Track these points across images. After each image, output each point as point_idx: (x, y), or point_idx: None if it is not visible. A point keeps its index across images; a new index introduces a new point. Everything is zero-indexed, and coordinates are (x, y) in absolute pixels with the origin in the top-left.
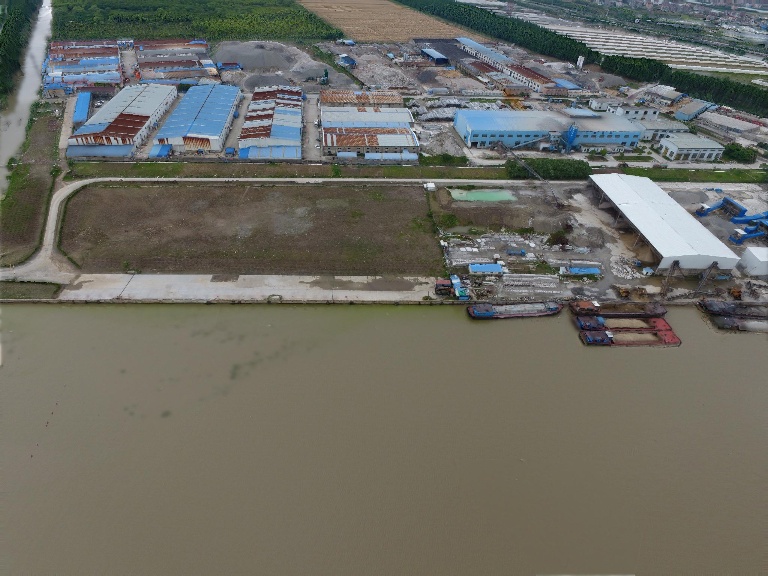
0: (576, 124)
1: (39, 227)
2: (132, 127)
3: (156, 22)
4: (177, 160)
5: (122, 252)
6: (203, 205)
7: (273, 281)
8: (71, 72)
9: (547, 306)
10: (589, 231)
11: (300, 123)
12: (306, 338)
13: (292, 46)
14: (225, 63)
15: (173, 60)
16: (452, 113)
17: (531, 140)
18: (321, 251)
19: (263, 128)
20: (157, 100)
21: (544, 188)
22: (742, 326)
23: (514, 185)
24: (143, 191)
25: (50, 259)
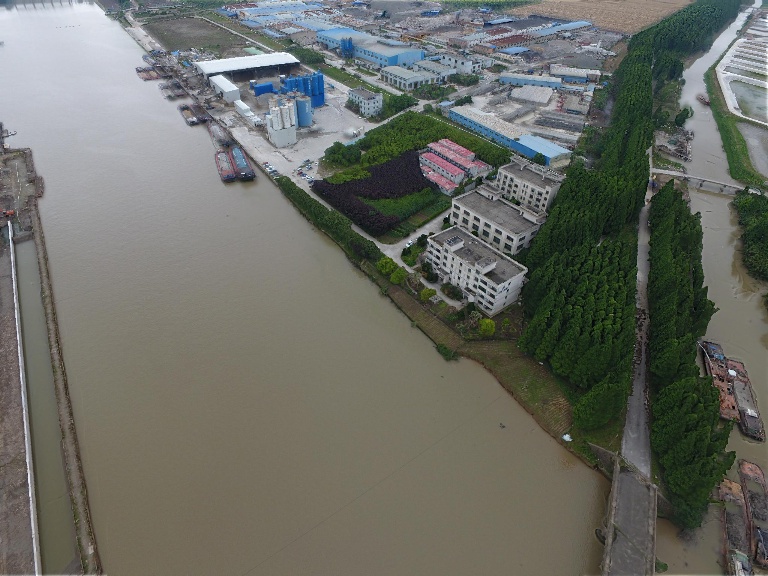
0: None
1: None
2: (242, 7)
3: None
4: None
5: None
6: (195, 27)
7: None
8: None
9: None
10: None
11: (285, 18)
12: None
13: (440, 6)
14: (362, 3)
15: None
16: None
17: None
18: None
19: None
20: (280, 4)
21: None
22: None
23: None
24: None
25: (144, 23)
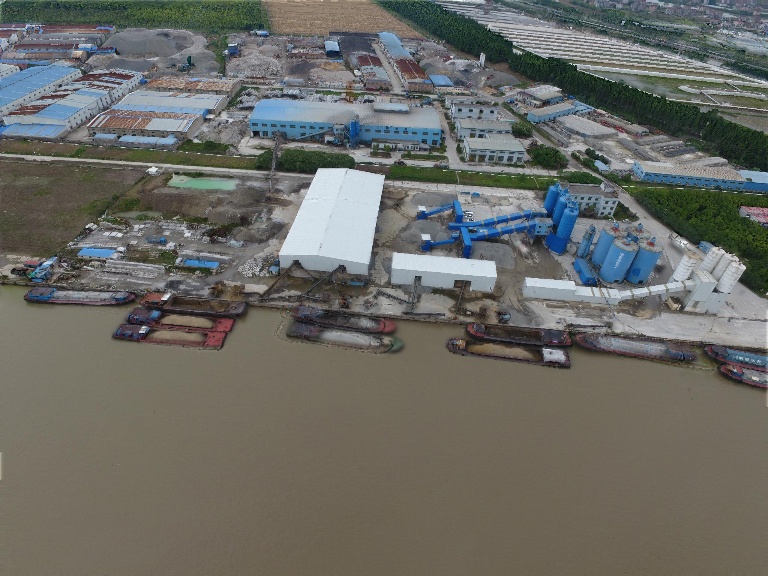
0: (356, 117)
1: None
2: None
3: (92, 9)
4: None
5: None
6: None
7: None
8: None
9: (113, 295)
10: (267, 225)
11: (88, 104)
12: None
13: (199, 35)
14: None
15: (56, 43)
16: None
17: (316, 132)
18: None
19: (40, 106)
20: None
21: (280, 180)
22: (317, 336)
23: (249, 175)
24: None
25: None
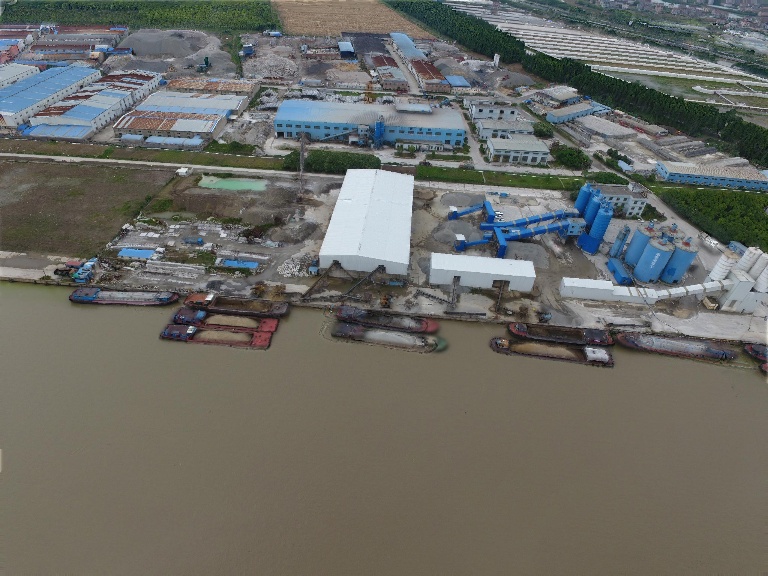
0: (381, 118)
1: None
2: None
3: (104, 10)
4: None
5: None
6: None
7: None
8: None
9: (157, 296)
10: (301, 226)
11: (112, 105)
12: None
13: (212, 36)
14: (117, 48)
15: (72, 44)
16: None
17: (340, 133)
18: None
19: (65, 107)
20: (1, 78)
21: (308, 181)
22: (361, 335)
23: (278, 176)
24: None
25: None
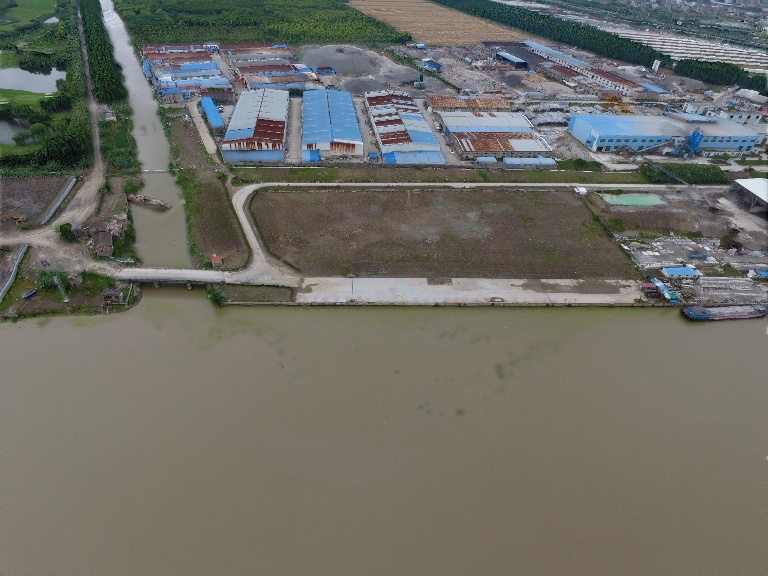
0: (702, 129)
1: (238, 231)
2: (275, 132)
3: (226, 26)
4: (327, 165)
5: (330, 256)
6: (377, 210)
7: (486, 284)
8: (178, 77)
9: (756, 308)
10: (753, 235)
11: None
12: (547, 339)
13: (369, 50)
14: (319, 67)
15: (267, 64)
16: (561, 118)
17: (654, 145)
18: (514, 255)
19: (400, 133)
20: (281, 105)
21: (687, 192)
22: None
23: (657, 189)
24: (313, 196)
25: (267, 263)
